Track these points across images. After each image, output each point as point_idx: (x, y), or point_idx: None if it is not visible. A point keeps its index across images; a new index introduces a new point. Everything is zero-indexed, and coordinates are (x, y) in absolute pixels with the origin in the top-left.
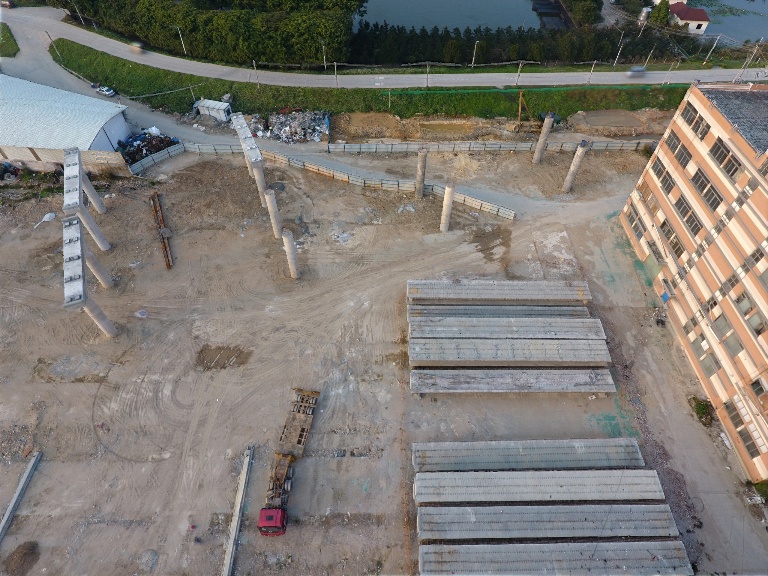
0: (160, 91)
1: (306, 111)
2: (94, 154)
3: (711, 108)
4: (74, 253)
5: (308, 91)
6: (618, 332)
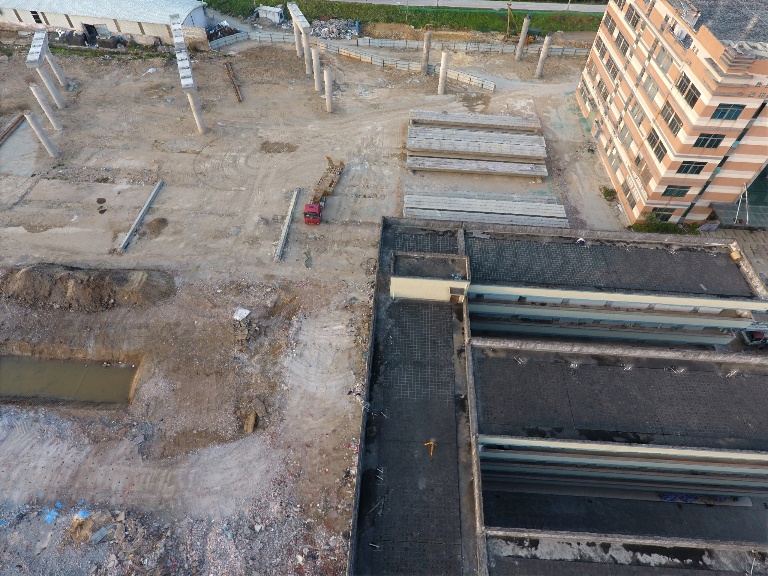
0: (228, 1)
1: (341, 19)
2: (185, 29)
3: None
4: (185, 65)
5: (343, 4)
6: (559, 153)
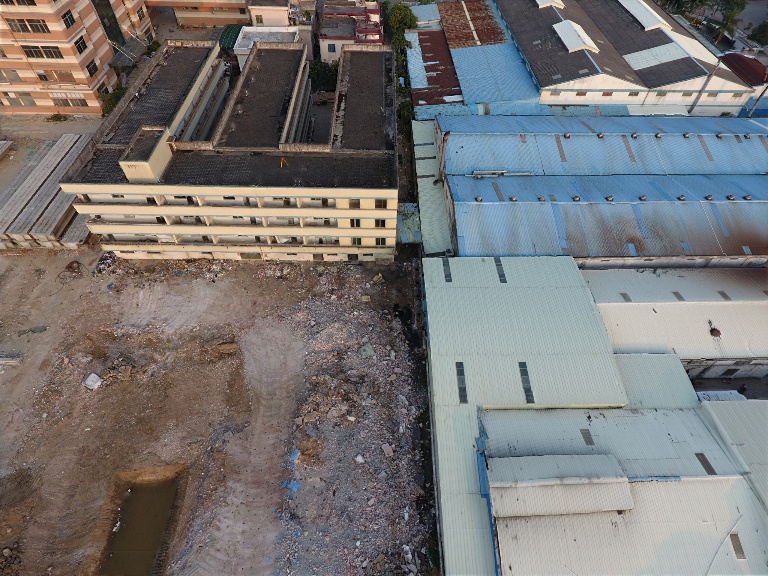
0: None
1: None
2: None
3: None
4: None
5: None
6: None
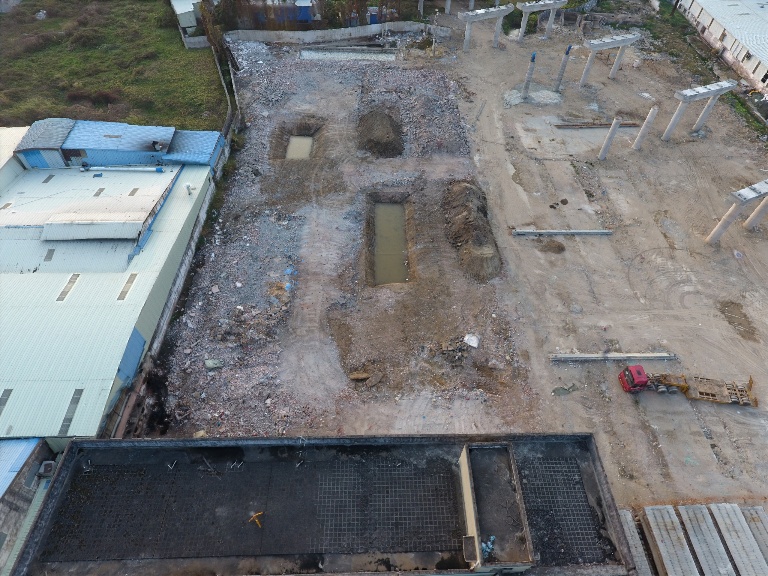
0: None
1: None
2: None
3: None
4: None
5: None
6: None
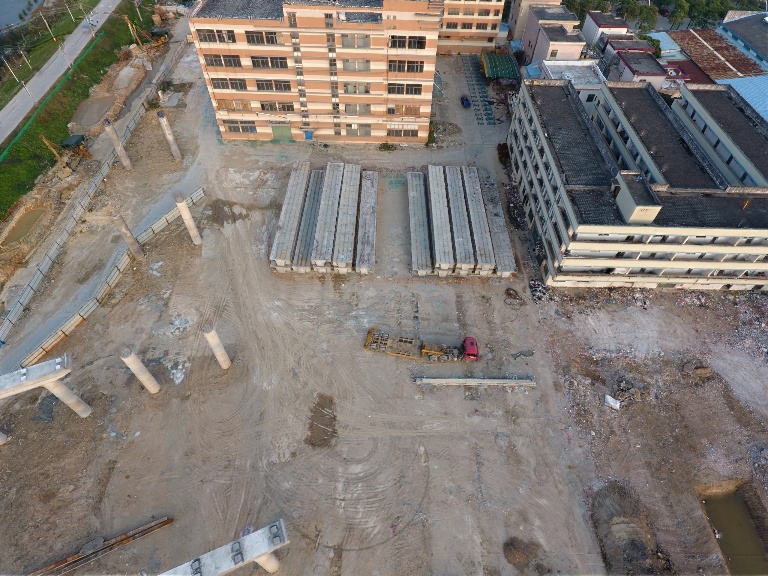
0: None
1: None
2: None
3: (222, 20)
4: (184, 573)
5: None
6: None
